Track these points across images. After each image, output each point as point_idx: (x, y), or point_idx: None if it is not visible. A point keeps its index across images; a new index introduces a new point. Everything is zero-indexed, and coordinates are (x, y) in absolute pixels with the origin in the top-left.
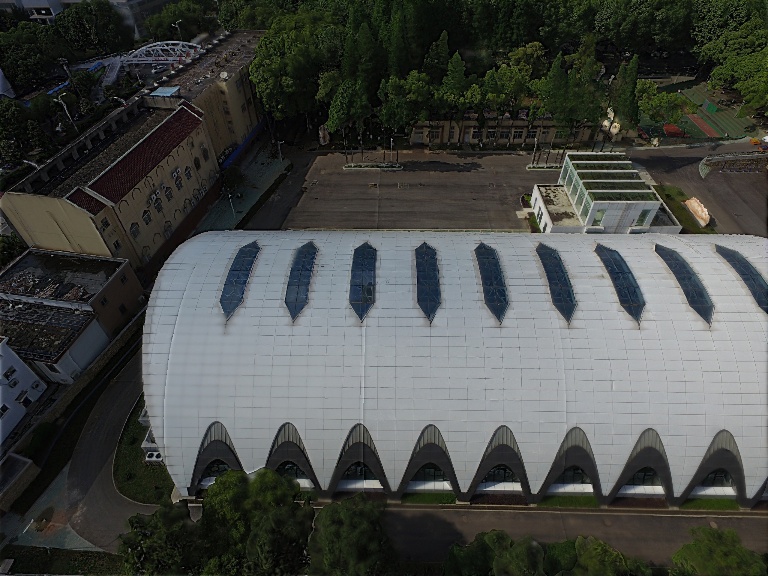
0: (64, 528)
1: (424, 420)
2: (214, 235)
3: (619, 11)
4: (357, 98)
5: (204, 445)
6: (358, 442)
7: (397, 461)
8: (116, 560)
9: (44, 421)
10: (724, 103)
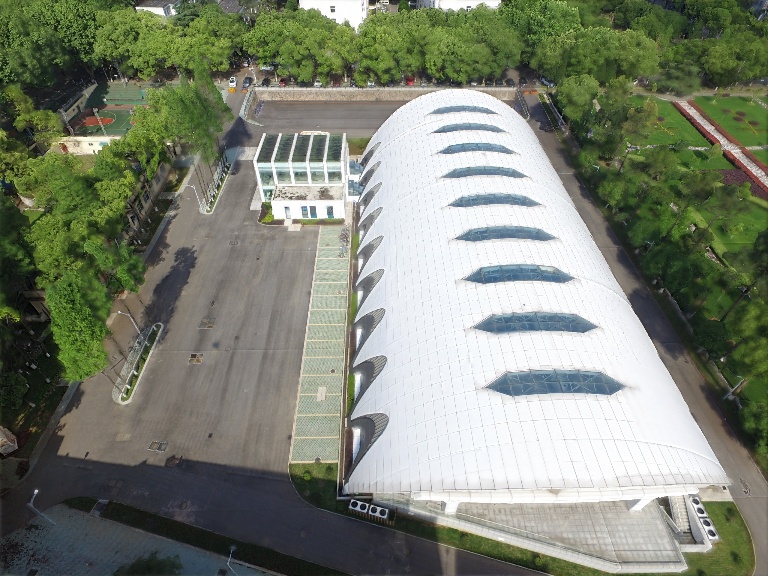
0: None
1: None
2: (471, 458)
3: (5, 51)
4: (92, 293)
5: None
6: None
7: None
8: None
9: None
10: (157, 85)
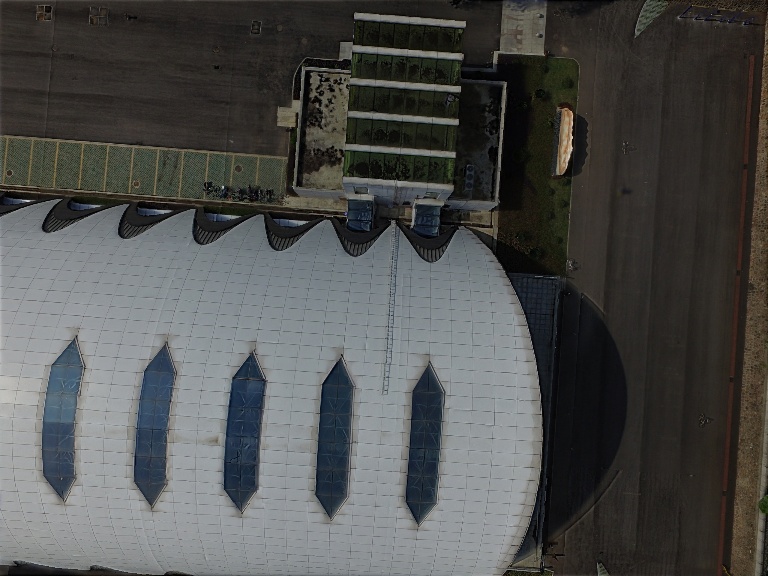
0: None
1: None
2: None
3: None
4: None
5: None
6: None
7: None
8: None
9: None
10: None
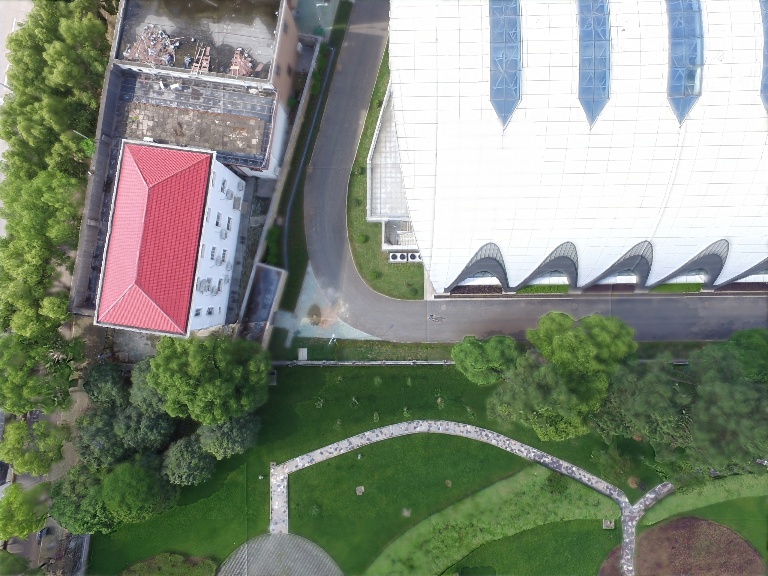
0: (337, 322)
1: (719, 236)
2: None
3: None
4: None
5: (472, 261)
6: (636, 255)
7: (668, 268)
8: (397, 347)
9: (269, 226)
10: None
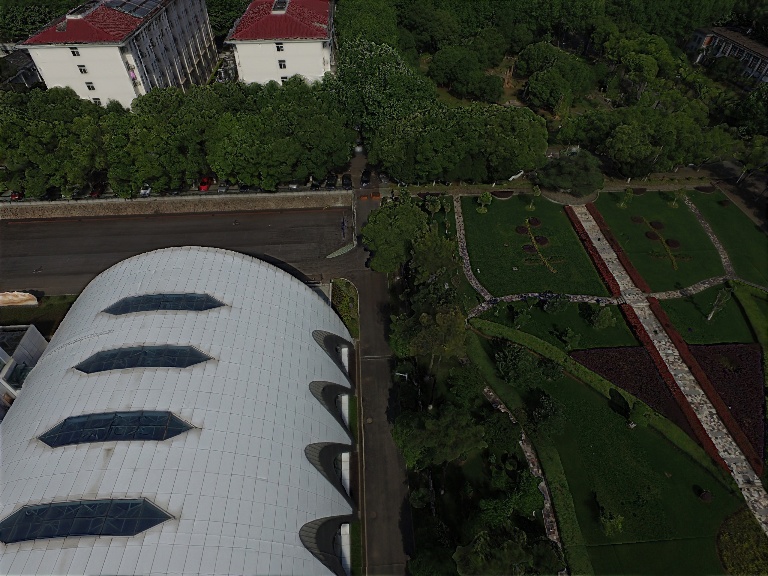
0: None
1: None
2: None
3: None
4: None
5: None
6: None
7: None
8: None
9: None
10: None
